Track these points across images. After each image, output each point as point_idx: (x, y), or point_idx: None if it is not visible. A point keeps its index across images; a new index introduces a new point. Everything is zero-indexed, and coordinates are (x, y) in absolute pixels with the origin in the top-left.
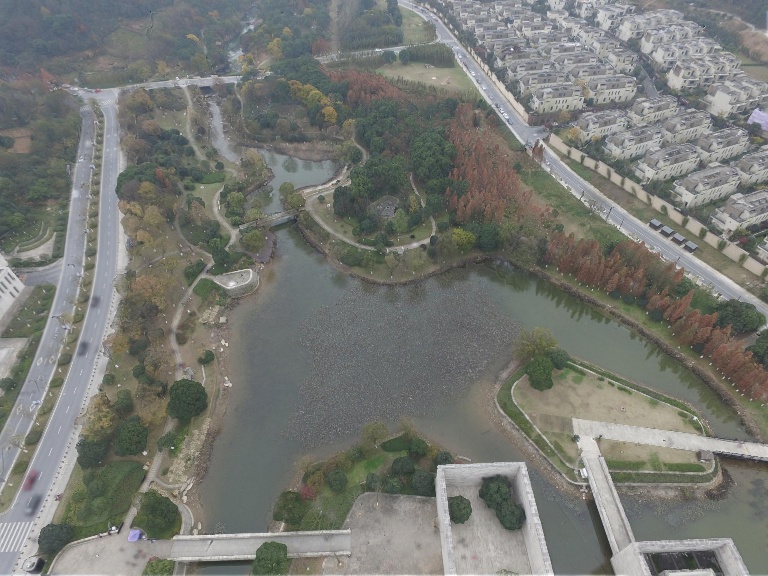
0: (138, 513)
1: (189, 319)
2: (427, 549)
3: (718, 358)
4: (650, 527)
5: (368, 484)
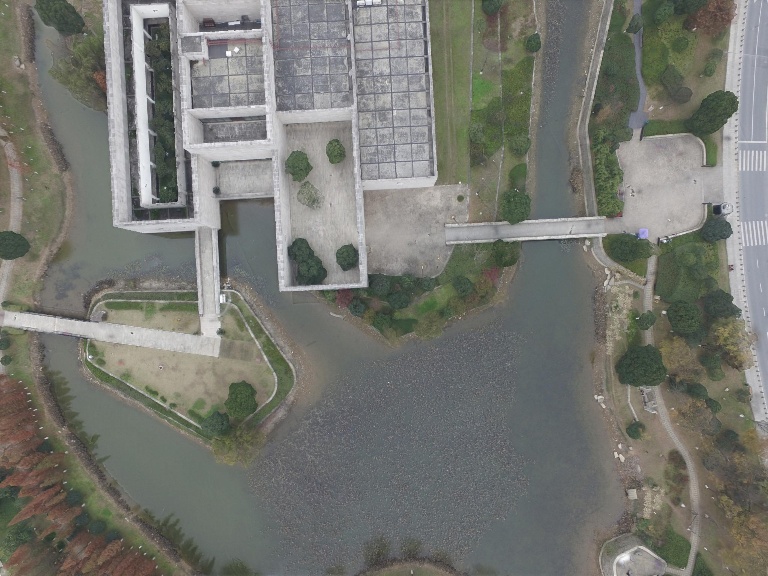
0: None
1: (678, 492)
2: (378, 230)
3: (29, 430)
4: (177, 257)
5: None
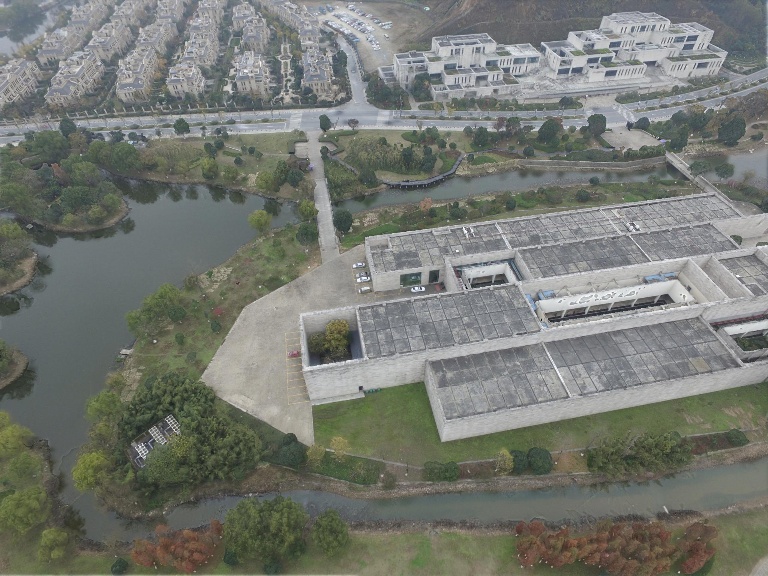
0: (678, 130)
1: None
2: None
3: None
4: None
5: (764, 198)
